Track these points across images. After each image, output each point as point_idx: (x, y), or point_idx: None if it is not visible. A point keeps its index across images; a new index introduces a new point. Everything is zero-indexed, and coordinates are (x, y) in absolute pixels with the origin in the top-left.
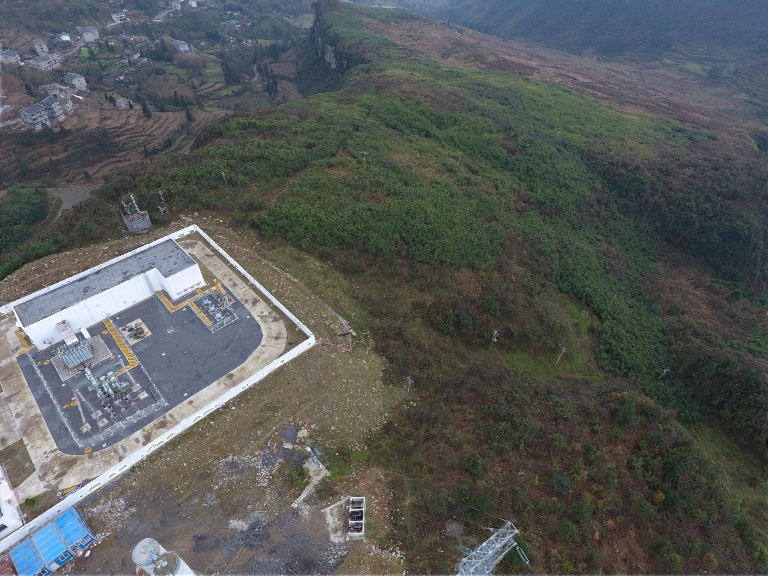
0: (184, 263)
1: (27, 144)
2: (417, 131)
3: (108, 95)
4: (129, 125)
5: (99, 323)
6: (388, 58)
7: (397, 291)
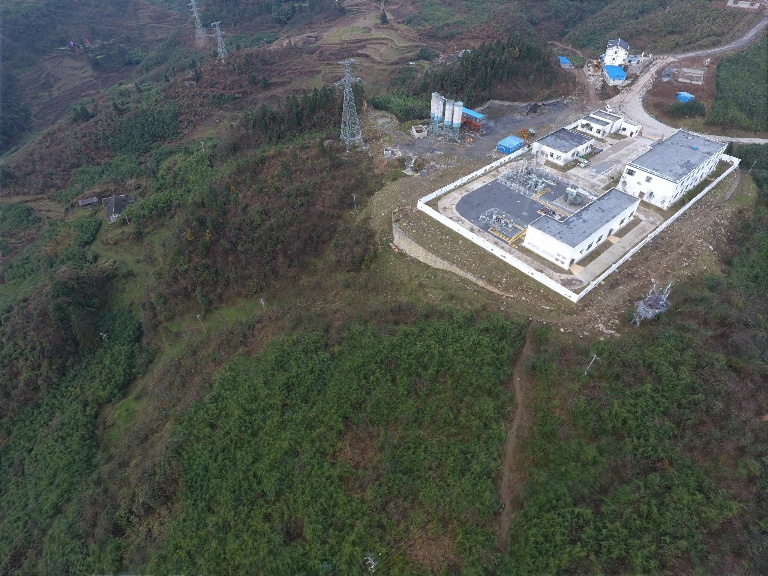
0: (541, 227)
1: None
2: None
3: None
4: None
5: None
6: None
7: None
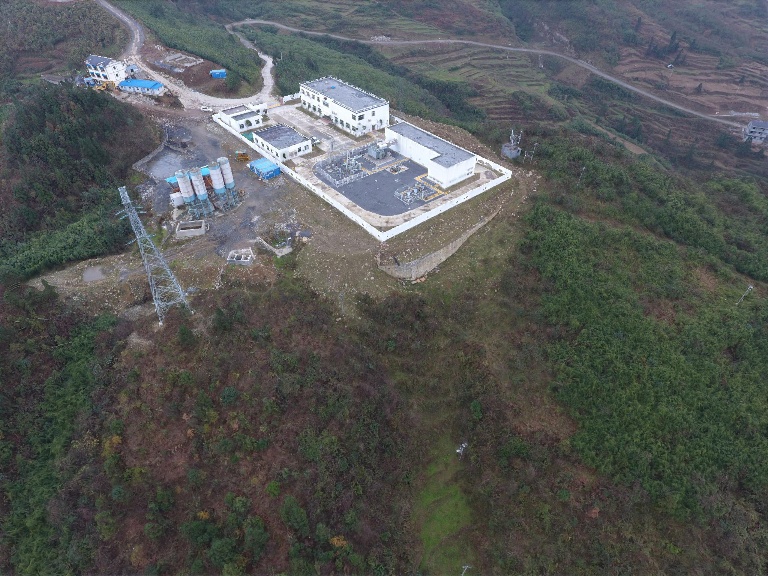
0: (448, 165)
1: (719, 144)
2: None
3: None
4: None
5: (406, 157)
6: None
7: (489, 327)
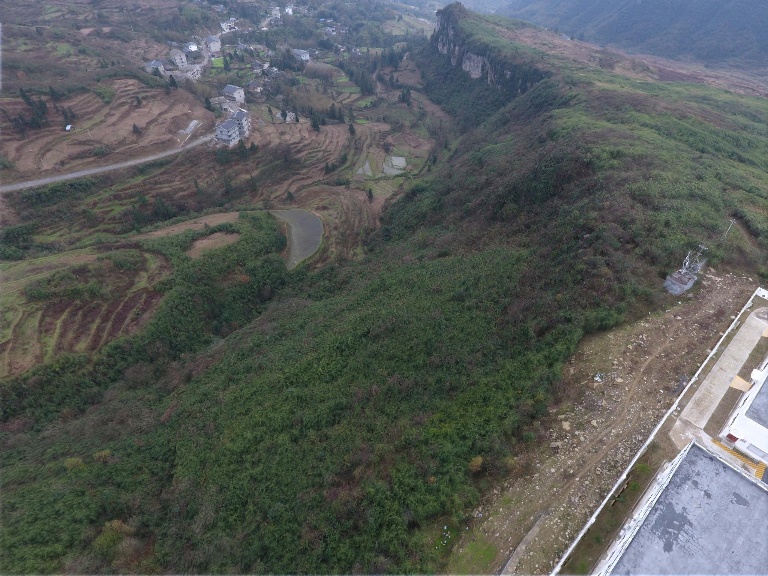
0: None
1: (225, 162)
2: (727, 155)
3: (266, 108)
4: (305, 140)
5: None
6: (567, 69)
7: None
